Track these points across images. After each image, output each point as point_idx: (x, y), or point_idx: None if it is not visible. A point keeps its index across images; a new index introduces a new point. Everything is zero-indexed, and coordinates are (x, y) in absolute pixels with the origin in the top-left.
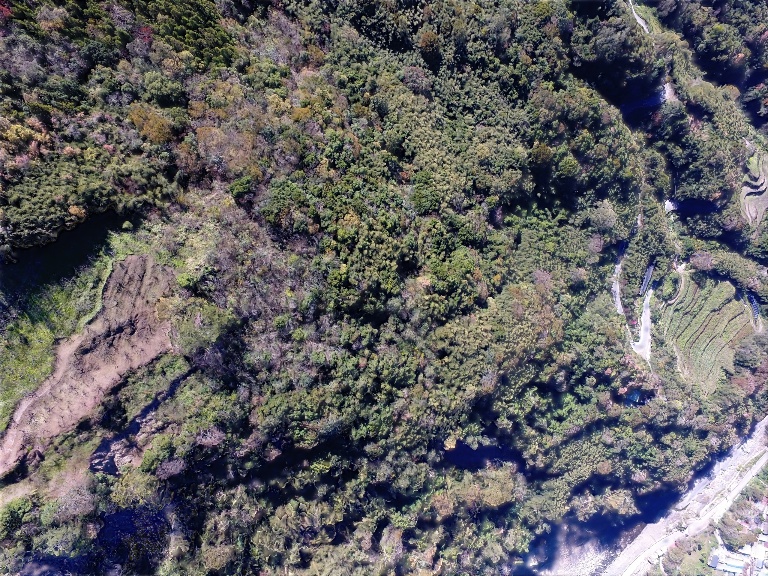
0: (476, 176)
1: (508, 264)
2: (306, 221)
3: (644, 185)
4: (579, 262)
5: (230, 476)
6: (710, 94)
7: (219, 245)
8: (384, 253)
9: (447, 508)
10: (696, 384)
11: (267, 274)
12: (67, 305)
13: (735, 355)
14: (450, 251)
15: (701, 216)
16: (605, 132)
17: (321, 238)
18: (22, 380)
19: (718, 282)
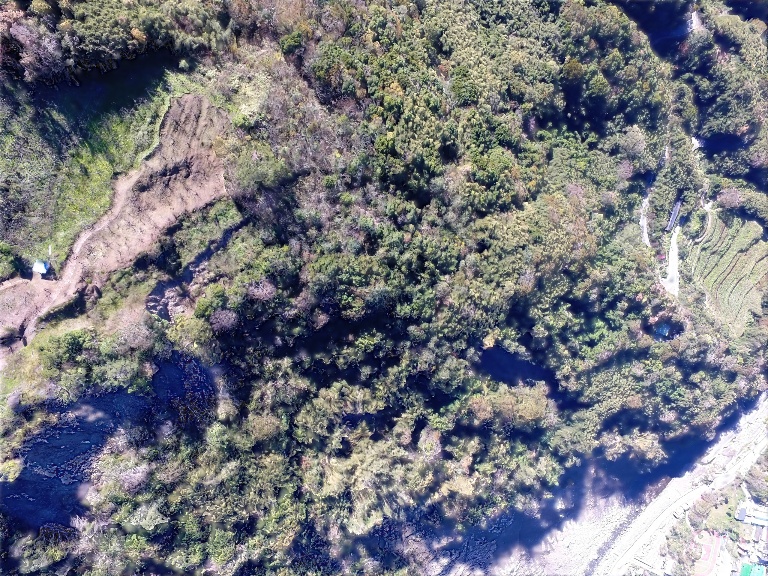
0: (511, 81)
1: (542, 173)
2: (354, 84)
3: (672, 116)
4: (609, 186)
5: (278, 342)
6: (737, 25)
7: (271, 95)
8: (427, 130)
9: (485, 411)
10: (725, 323)
11: (317, 130)
12: (126, 138)
13: (763, 297)
14: (487, 148)
15: (728, 153)
16: (635, 53)
17: (368, 105)
18: (81, 212)
19: (745, 222)
